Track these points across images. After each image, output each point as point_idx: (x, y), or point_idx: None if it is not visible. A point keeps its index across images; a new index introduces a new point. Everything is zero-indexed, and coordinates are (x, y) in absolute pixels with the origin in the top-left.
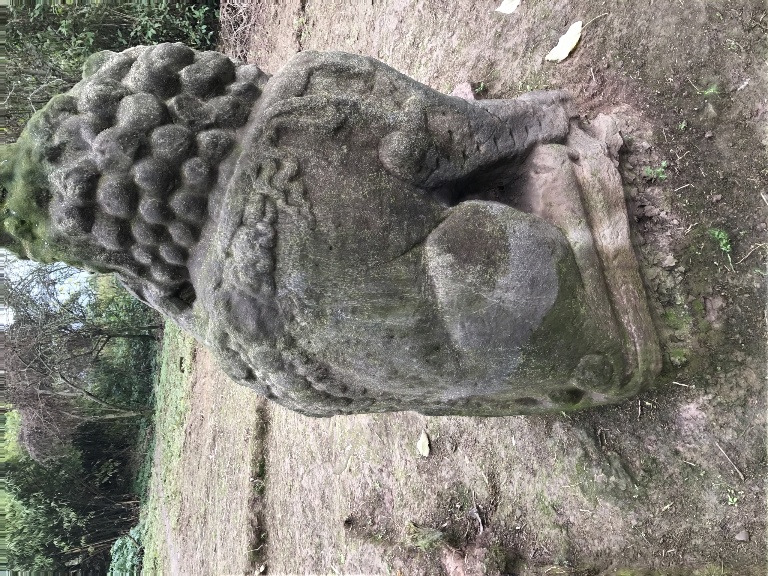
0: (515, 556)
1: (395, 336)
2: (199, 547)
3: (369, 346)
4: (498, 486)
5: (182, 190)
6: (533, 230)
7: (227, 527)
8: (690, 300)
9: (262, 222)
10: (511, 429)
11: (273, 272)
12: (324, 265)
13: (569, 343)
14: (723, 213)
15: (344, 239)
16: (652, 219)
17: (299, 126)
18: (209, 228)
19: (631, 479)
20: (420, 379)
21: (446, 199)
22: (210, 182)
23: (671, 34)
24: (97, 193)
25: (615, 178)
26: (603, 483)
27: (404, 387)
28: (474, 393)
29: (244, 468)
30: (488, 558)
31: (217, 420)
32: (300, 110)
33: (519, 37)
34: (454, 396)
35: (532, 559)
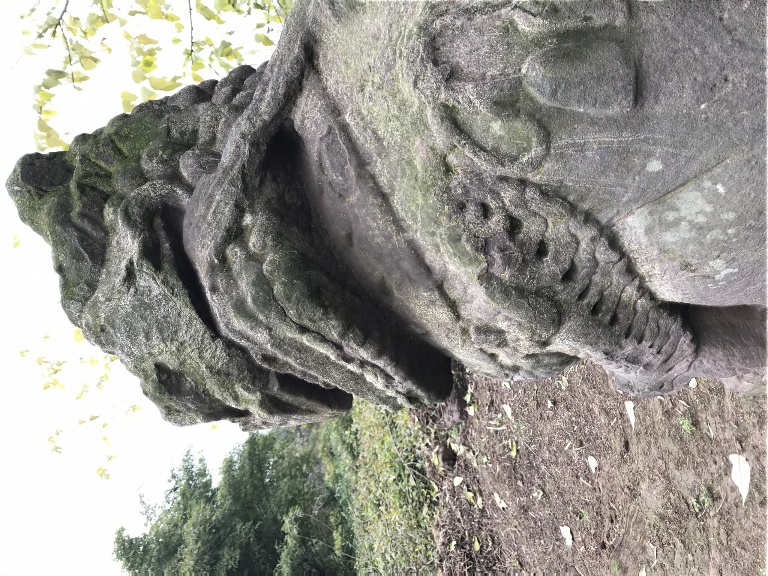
0: None
1: None
2: None
3: None
4: None
5: None
6: None
7: None
8: None
9: None
10: None
11: None
12: None
13: None
14: None
15: None
16: None
17: None
18: None
19: None
20: None
21: None
22: None
23: None
24: None
25: None
26: None
27: None
28: None
29: None
30: None
31: None
32: None
33: (767, 448)
34: None
35: None
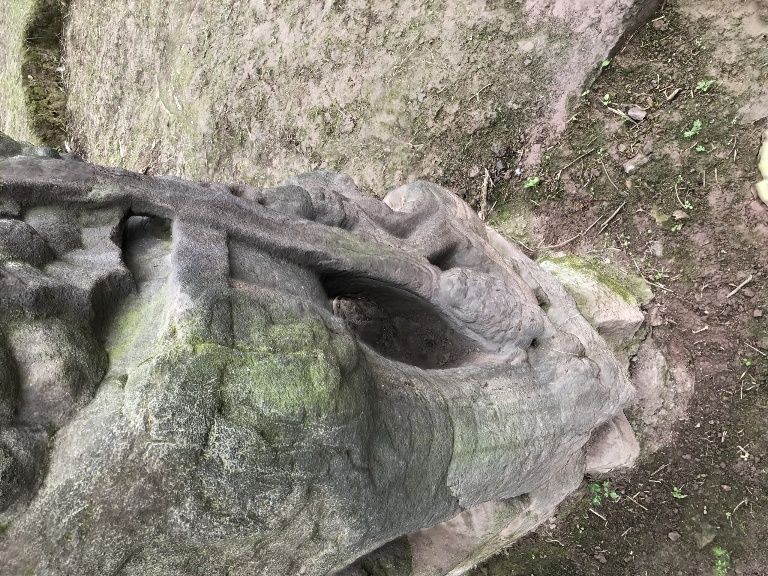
0: None
1: None
2: None
3: None
4: None
5: None
6: None
7: None
8: (482, 571)
9: None
10: None
11: None
12: None
13: None
14: (586, 570)
15: None
16: None
17: None
18: None
19: None
20: None
21: None
22: None
23: None
24: None
25: None
26: None
27: None
28: None
29: None
30: None
31: None
32: None
33: None
34: None
35: None
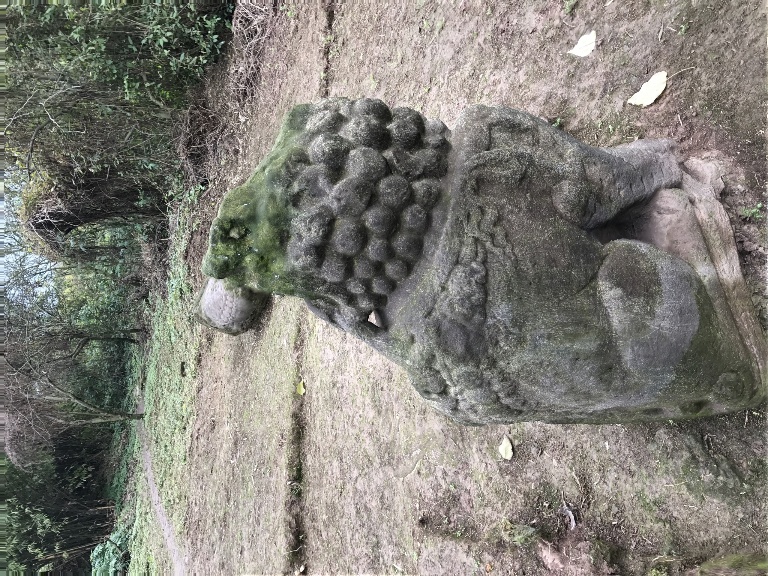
0: (617, 548)
1: (580, 358)
2: (218, 550)
3: (558, 367)
4: (590, 486)
5: (403, 233)
6: (674, 266)
7: (256, 530)
8: None
9: (476, 262)
10: (604, 435)
11: (485, 304)
12: (526, 298)
13: (711, 363)
14: None
15: (540, 276)
16: (751, 253)
17: (493, 177)
18: (422, 265)
19: (739, 478)
20: (589, 394)
21: (598, 238)
22: (427, 226)
23: (762, 92)
24: (334, 235)
25: (725, 219)
26: (711, 482)
27: (570, 401)
28: (621, 405)
29: (277, 472)
30: (593, 550)
31: (238, 425)
32: (491, 163)
33: (595, 79)
34: (601, 408)
35: (634, 550)
